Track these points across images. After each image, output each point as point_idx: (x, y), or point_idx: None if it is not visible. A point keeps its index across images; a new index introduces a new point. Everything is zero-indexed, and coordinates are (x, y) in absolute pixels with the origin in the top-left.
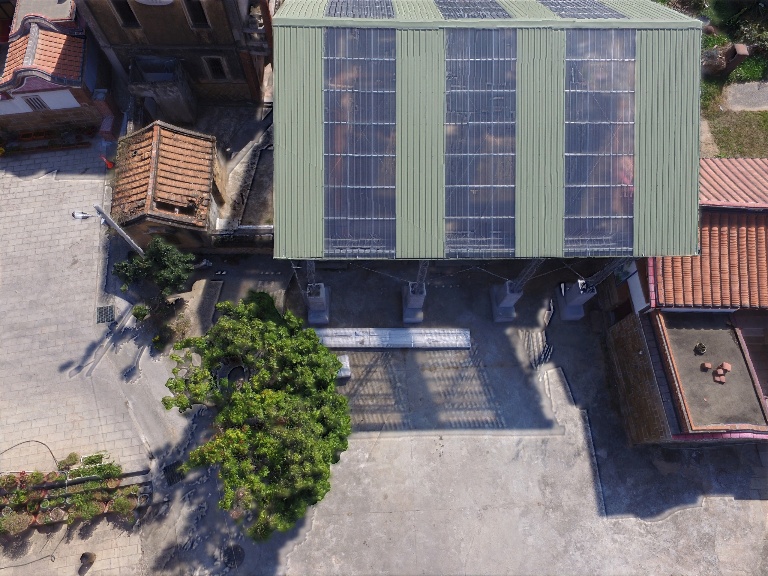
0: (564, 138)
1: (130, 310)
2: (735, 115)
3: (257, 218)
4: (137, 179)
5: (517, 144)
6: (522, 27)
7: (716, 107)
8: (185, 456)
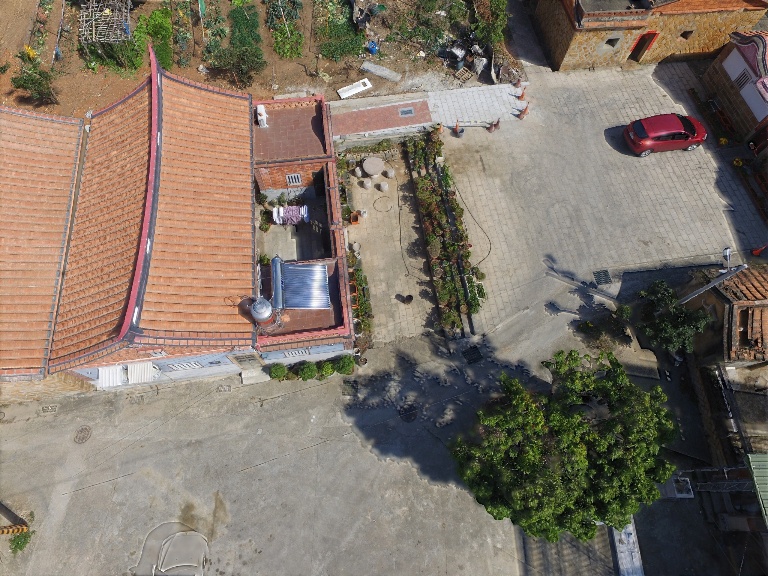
0: None
1: (611, 297)
2: None
3: (743, 408)
4: (765, 287)
5: None
6: None
7: None
8: (487, 362)
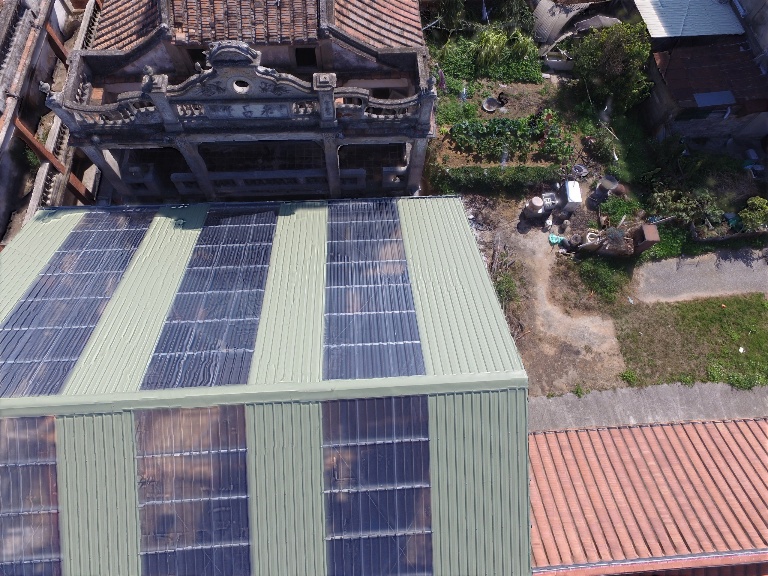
0: (325, 562)
1: None
2: (647, 309)
3: None
4: None
5: (253, 575)
6: (253, 402)
7: (624, 299)
8: None
